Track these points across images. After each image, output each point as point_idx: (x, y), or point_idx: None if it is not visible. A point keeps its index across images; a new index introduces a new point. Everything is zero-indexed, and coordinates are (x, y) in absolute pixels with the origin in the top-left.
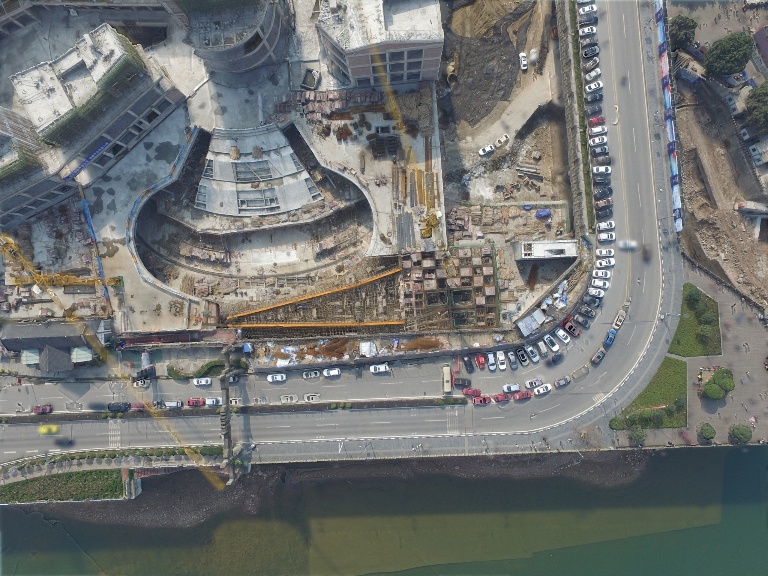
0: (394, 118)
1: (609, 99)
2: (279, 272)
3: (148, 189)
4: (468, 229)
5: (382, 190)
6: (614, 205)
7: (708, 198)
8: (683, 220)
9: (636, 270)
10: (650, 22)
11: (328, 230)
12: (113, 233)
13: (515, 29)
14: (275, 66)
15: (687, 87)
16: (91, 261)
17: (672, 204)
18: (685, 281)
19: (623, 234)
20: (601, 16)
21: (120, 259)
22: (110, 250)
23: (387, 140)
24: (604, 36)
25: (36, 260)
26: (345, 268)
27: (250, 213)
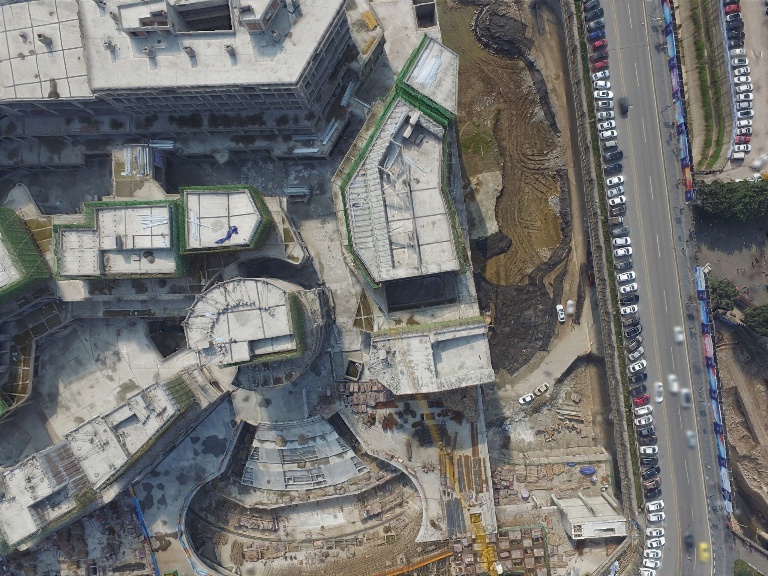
0: (439, 406)
1: (653, 377)
2: (327, 535)
3: (197, 485)
4: (513, 486)
5: (430, 476)
6: (662, 483)
7: (749, 430)
8: (733, 503)
9: (686, 547)
10: (692, 298)
11: (374, 493)
12: (165, 527)
13: (551, 280)
14: (317, 358)
15: (725, 327)
16: (145, 556)
17: (720, 482)
18: (736, 558)
19: (672, 512)
20: (642, 293)
21: (173, 553)
22: (163, 544)
23: (433, 430)
24: (646, 313)
25: (90, 557)
26: (392, 529)
27: (297, 487)
